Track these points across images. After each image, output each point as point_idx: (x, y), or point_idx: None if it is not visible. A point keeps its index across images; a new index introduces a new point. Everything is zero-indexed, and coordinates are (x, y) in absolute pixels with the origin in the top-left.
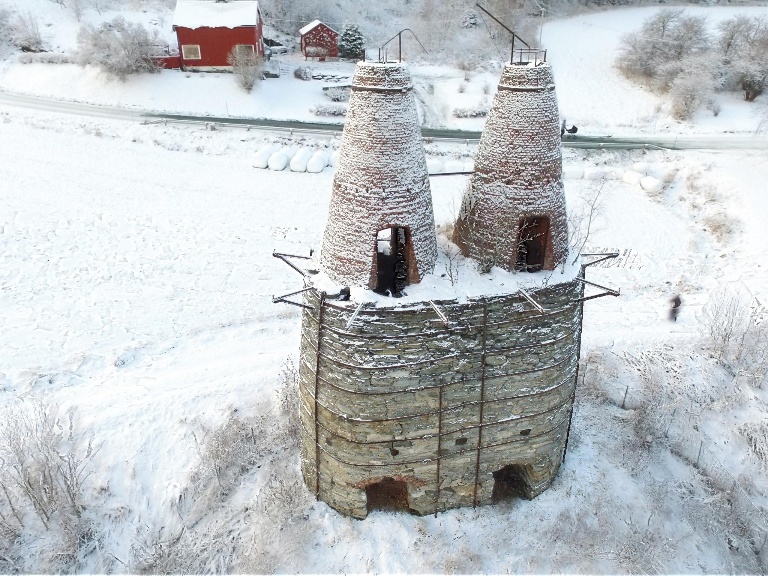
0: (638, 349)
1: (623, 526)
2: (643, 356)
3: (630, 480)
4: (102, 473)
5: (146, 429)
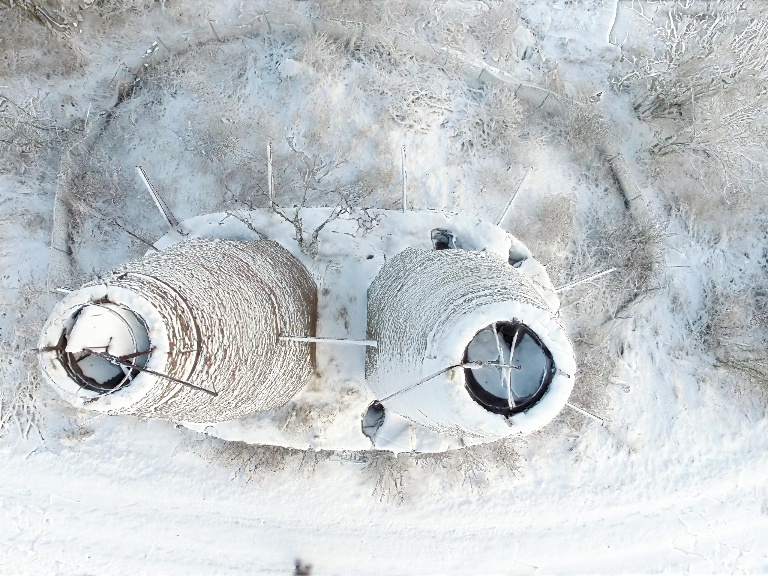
0: (4, 435)
1: (208, 180)
2: (7, 419)
3: (165, 229)
4: (709, 401)
5: (674, 450)
